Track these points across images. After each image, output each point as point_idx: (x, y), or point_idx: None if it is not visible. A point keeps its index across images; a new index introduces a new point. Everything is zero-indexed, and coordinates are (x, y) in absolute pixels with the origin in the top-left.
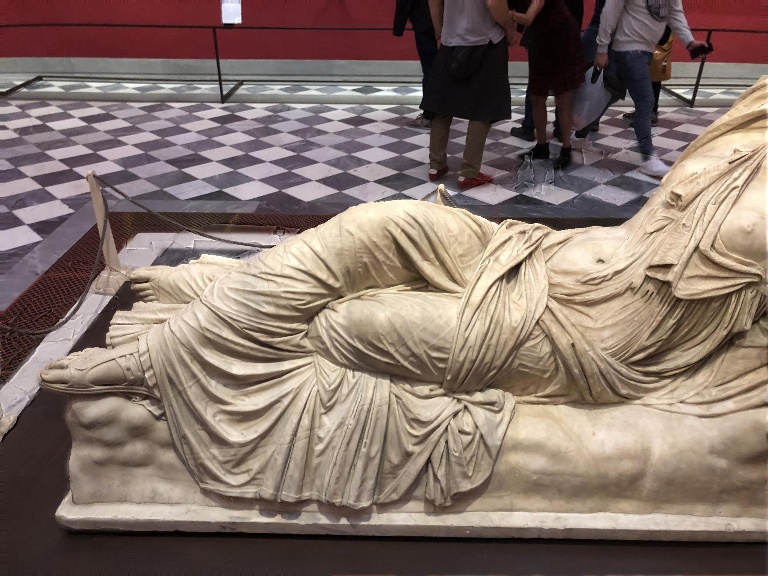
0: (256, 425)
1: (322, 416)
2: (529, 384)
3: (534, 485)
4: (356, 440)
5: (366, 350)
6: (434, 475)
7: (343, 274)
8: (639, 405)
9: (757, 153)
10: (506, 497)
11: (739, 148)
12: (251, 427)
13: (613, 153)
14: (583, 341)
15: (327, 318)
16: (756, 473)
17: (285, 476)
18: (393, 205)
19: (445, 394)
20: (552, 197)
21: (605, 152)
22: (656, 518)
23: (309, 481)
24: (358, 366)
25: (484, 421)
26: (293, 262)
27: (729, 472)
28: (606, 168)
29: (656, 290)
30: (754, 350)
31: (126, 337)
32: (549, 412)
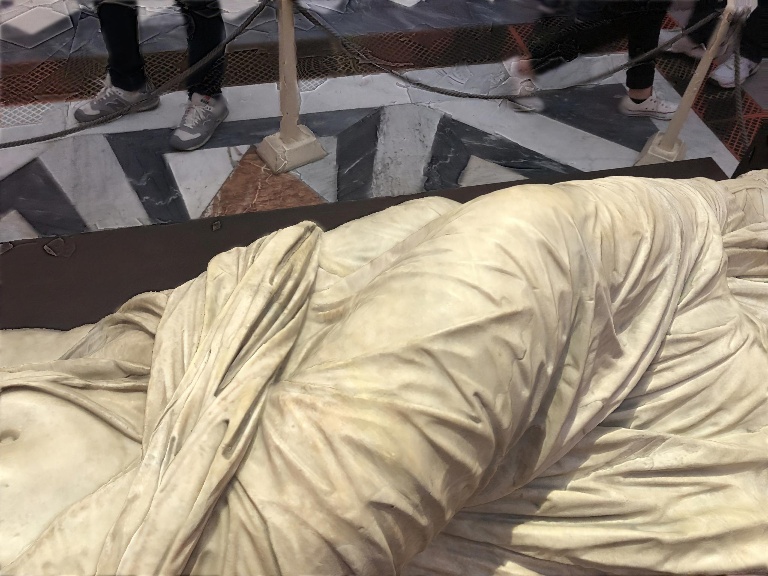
0: None
1: None
2: None
3: None
4: None
5: None
6: None
7: None
8: None
9: None
10: None
11: None
12: None
13: None
14: None
15: None
16: None
17: None
18: (486, 230)
19: None
20: None
21: None
22: None
23: None
24: None
25: None
26: None
27: None
28: None
29: None
30: None
31: (765, 222)
32: None
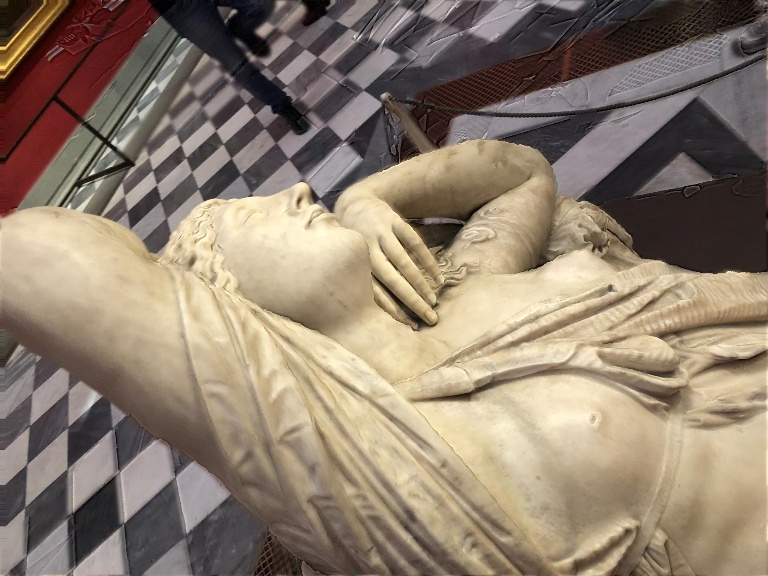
0: None
1: None
2: None
3: None
4: None
5: None
6: None
7: None
8: None
9: None
10: None
11: (465, 375)
12: None
13: None
14: None
15: None
16: None
17: None
18: None
19: None
20: None
21: None
22: None
23: None
24: None
25: None
26: None
27: None
28: None
29: None
30: None
31: None
32: None
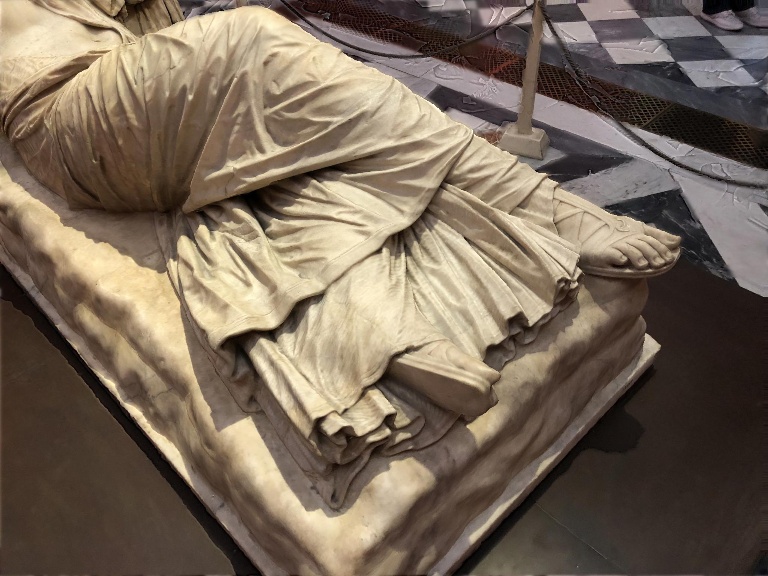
0: None
1: None
2: None
3: None
4: None
5: None
6: None
7: None
8: None
9: None
10: None
11: None
12: None
13: None
14: None
15: None
16: None
17: None
18: None
19: None
20: None
21: None
22: None
23: None
24: None
25: None
26: None
27: None
28: None
29: None
30: None
31: None
32: None
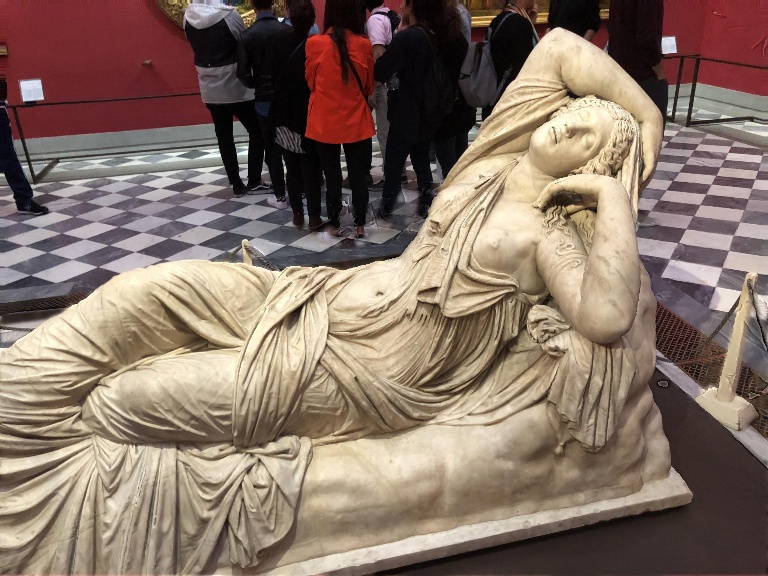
0: (33, 525)
1: (107, 500)
2: (324, 424)
3: (340, 524)
4: (145, 518)
5: (143, 421)
6: (235, 537)
7: (111, 347)
8: (433, 425)
9: (499, 177)
10: (315, 543)
11: (483, 174)
12: (27, 529)
13: (432, 189)
14: (366, 373)
15: (100, 395)
16: (539, 468)
17: (71, 574)
18: (159, 269)
19: (237, 451)
20: (375, 237)
21: (425, 189)
22: (461, 531)
23: (101, 573)
24: (140, 440)
25: (279, 471)
26: (52, 343)
27: (516, 472)
28: (425, 203)
29: (429, 313)
30: (524, 354)
31: None
32: (348, 448)
